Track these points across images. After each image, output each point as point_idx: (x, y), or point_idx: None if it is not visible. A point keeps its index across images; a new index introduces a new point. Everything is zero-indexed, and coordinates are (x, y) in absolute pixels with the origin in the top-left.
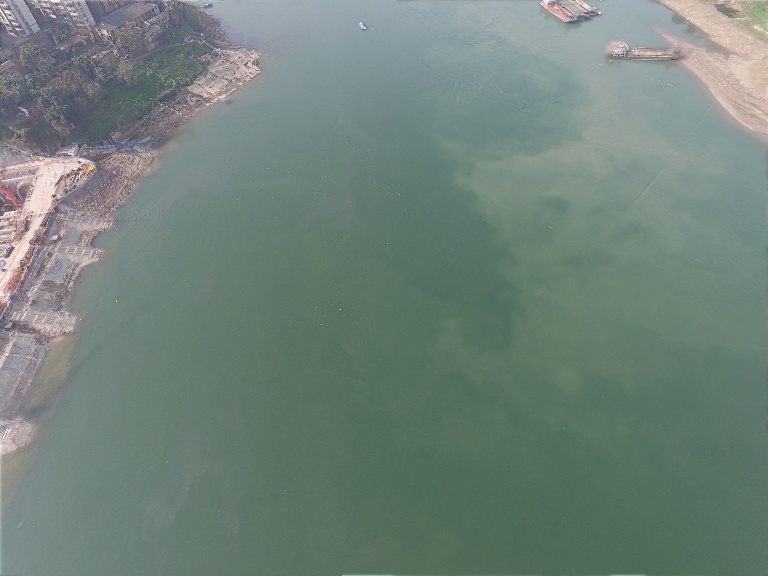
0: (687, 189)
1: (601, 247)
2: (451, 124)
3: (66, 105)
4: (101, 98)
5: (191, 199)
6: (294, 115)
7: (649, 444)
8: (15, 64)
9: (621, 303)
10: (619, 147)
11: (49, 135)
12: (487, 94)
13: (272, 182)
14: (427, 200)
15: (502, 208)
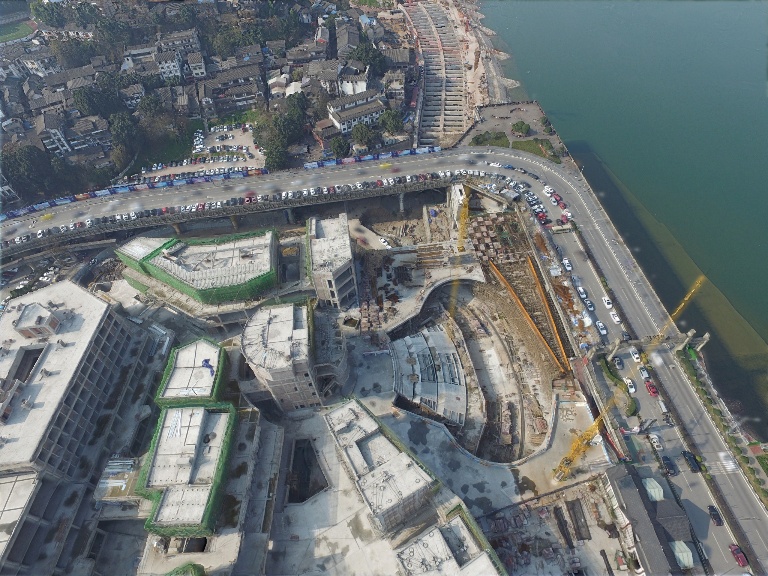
0: None
1: (756, 4)
2: None
3: None
4: None
5: None
6: None
7: None
8: None
9: None
10: None
11: None
12: None
13: None
14: None
15: None
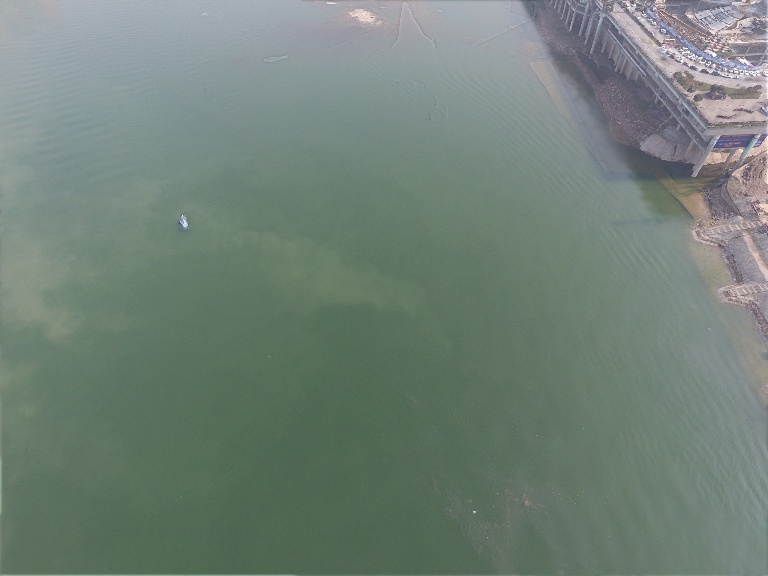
0: None
1: None
2: None
3: None
4: None
5: None
6: None
7: (210, 339)
8: None
9: (111, 492)
10: None
11: None
12: None
13: None
14: None
15: None
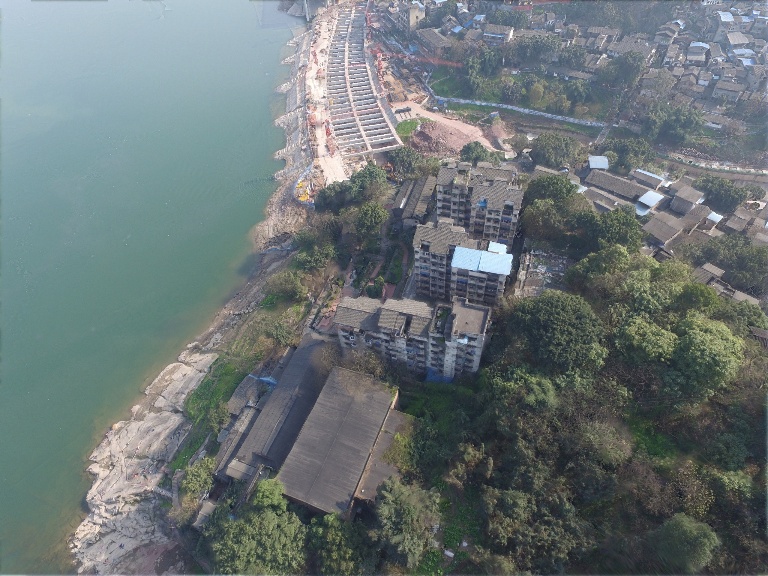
0: None
1: None
2: None
3: (315, 197)
4: None
5: (209, 199)
6: (71, 324)
7: None
8: (392, 209)
9: None
10: None
11: None
12: None
13: (129, 220)
14: None
15: None
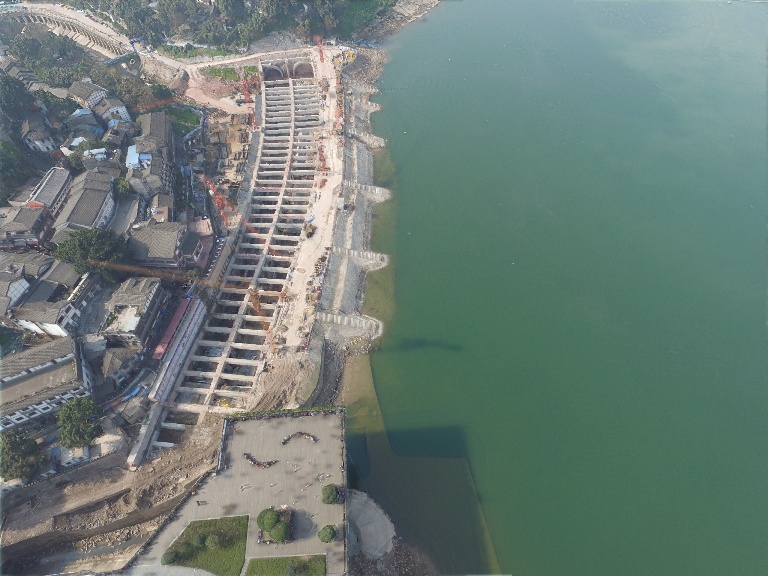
0: None
1: (753, 114)
2: (613, 38)
3: (335, 5)
4: (343, 7)
5: (429, 78)
6: (482, 30)
7: None
8: None
9: None
10: (751, 57)
11: (319, 27)
12: (632, 21)
13: (486, 70)
14: (613, 82)
15: (672, 89)
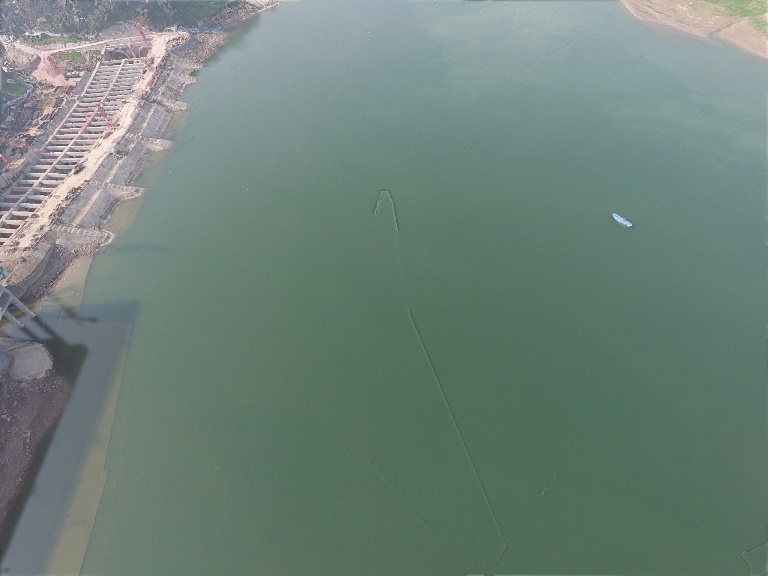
0: (585, 51)
1: (515, 74)
2: (429, 18)
3: None
4: None
5: (252, 55)
6: (320, 15)
7: (519, 150)
8: None
9: (522, 101)
10: (544, 29)
11: (160, 16)
12: (458, 4)
13: (304, 47)
14: (406, 53)
15: None
